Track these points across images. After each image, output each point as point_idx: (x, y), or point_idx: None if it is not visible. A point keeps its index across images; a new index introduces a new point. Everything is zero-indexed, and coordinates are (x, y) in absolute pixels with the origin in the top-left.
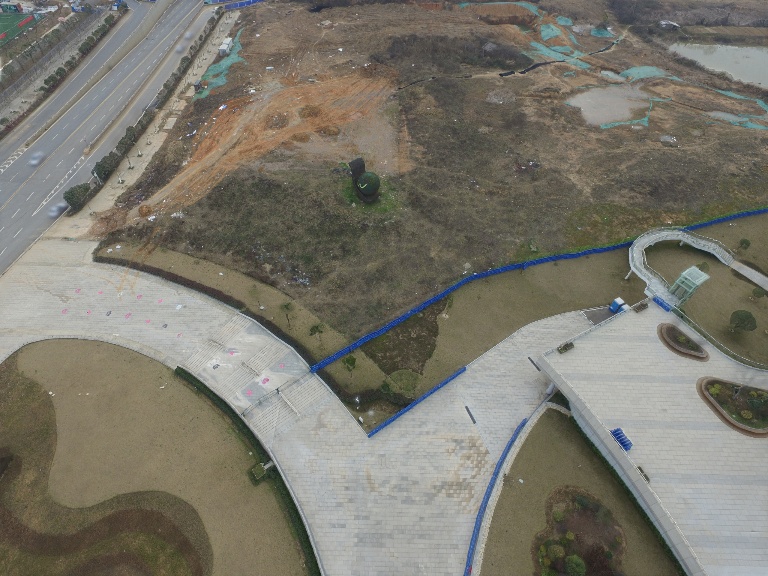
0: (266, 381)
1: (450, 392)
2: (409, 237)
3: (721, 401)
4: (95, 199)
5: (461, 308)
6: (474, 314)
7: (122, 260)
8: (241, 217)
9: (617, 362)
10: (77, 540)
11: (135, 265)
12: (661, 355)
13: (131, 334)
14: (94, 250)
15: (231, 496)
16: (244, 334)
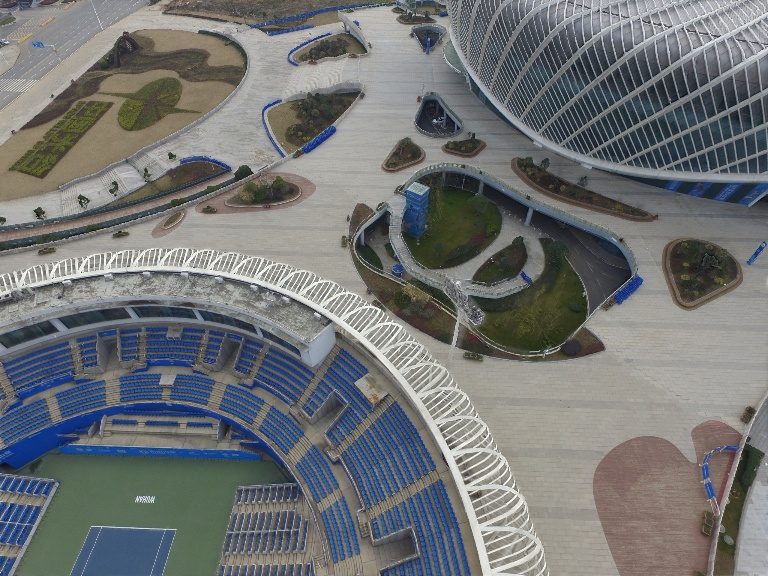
0: (233, 30)
1: (305, 30)
2: (304, 1)
3: (401, 17)
4: (161, 1)
5: (319, 17)
6: (324, 18)
7: (175, 13)
8: (229, 1)
9: (369, 14)
10: (165, 55)
11: (181, 14)
12: (388, 13)
13: (180, 28)
14: (163, 12)
15: (218, 47)
16: (226, 25)
